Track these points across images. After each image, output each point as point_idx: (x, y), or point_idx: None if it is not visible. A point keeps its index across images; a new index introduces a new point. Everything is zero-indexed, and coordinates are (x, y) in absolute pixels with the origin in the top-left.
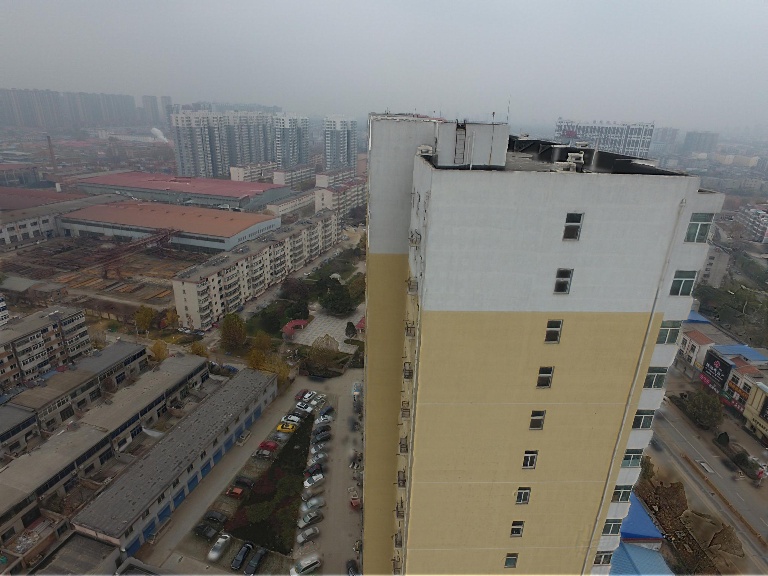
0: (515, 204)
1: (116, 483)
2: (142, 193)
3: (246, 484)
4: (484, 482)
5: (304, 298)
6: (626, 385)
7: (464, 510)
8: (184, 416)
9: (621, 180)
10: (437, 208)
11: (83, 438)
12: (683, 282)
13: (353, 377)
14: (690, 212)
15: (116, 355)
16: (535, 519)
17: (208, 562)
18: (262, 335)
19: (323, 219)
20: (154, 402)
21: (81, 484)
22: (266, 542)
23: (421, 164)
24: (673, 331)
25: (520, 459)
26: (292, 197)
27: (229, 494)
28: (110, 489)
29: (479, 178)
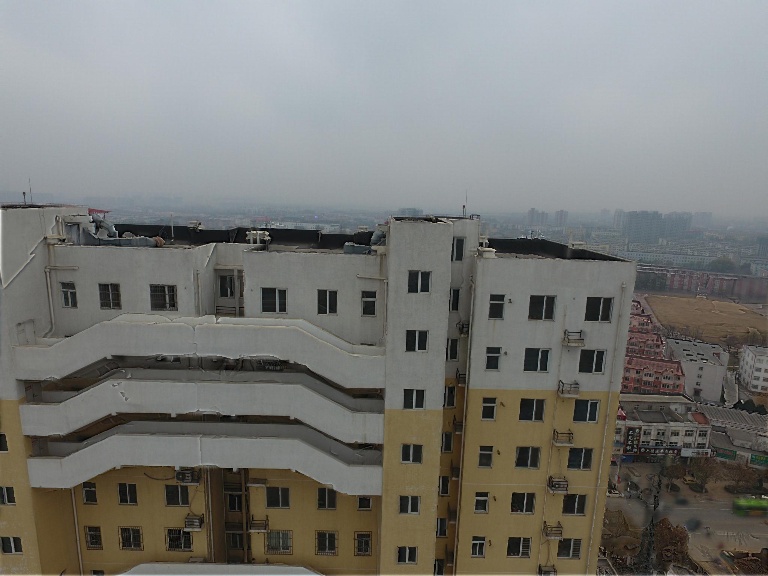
0: None
1: None
2: None
3: None
4: None
5: None
6: None
7: None
8: None
9: None
10: None
11: None
12: None
13: None
14: None
15: None
16: None
17: None
18: None
19: None
20: None
21: None
22: None
23: (556, 264)
24: None
25: None
26: None
27: None
28: None
29: None
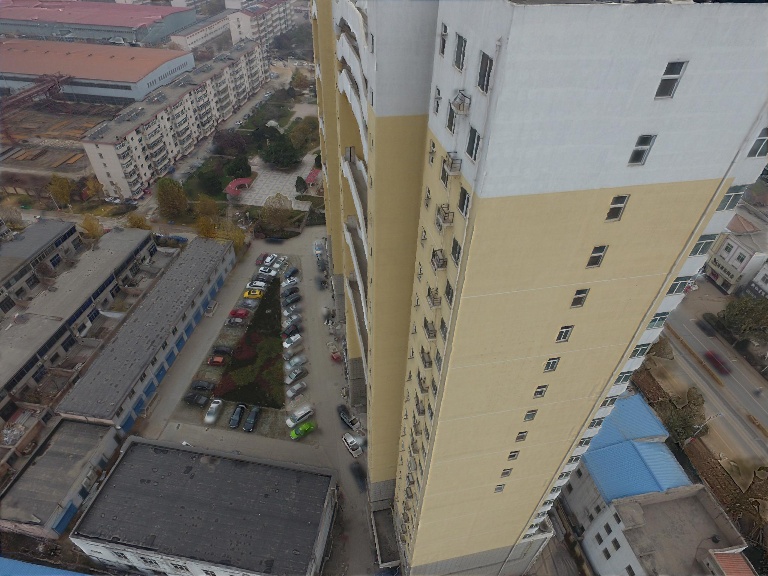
0: (611, 53)
1: (90, 369)
2: (2, 26)
3: (225, 352)
4: (518, 359)
5: (241, 152)
6: (673, 255)
7: (495, 384)
8: (142, 294)
9: (744, 12)
10: (513, 64)
11: (37, 329)
12: (765, 141)
13: (312, 235)
14: None
15: (42, 236)
16: (558, 382)
17: (206, 425)
18: (206, 199)
19: (245, 53)
20: (104, 283)
21: (51, 373)
22: (258, 401)
23: None
24: (736, 196)
25: (555, 335)
26: (200, 24)
27: (210, 363)
28: (86, 376)
29: (574, 16)
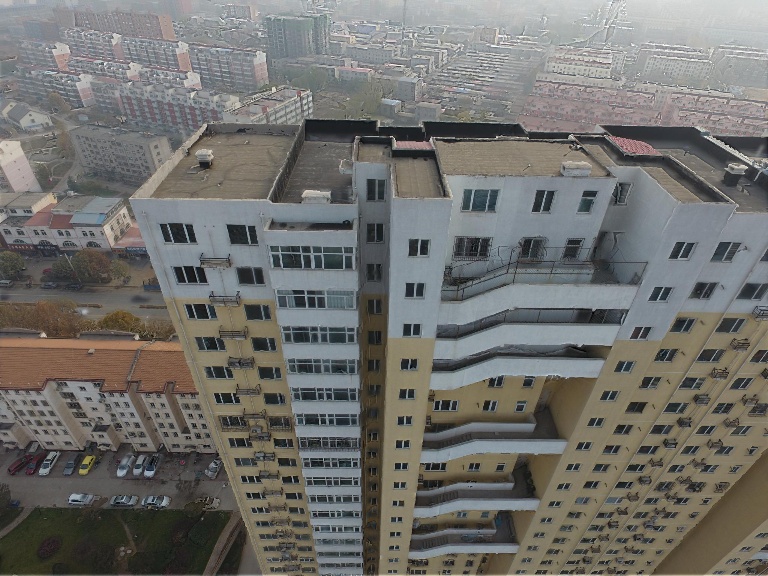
0: None
1: None
2: None
3: None
4: None
5: None
6: None
7: None
8: None
9: None
10: None
11: None
12: None
13: None
14: None
15: None
16: None
17: None
18: None
19: None
20: None
21: None
22: None
23: None
24: None
25: None
26: None
27: None
28: None
29: None
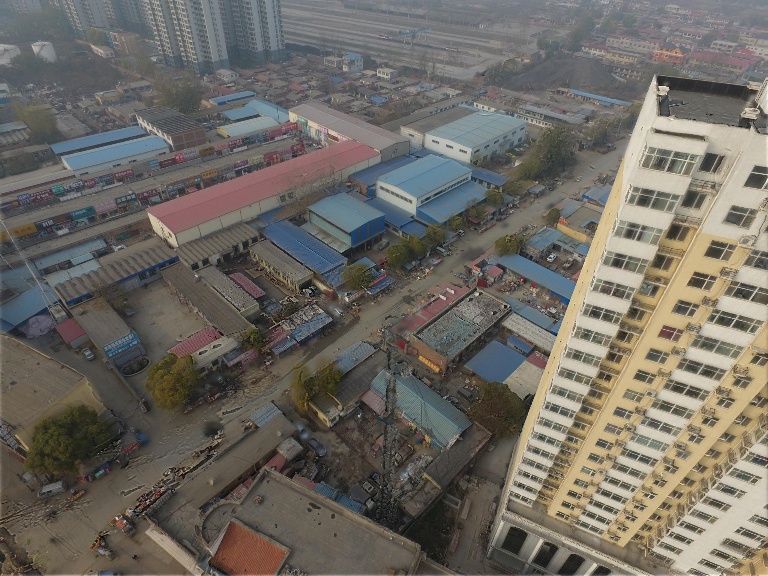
0: None
1: None
2: None
3: None
4: None
5: None
6: None
7: None
8: None
9: None
10: None
11: None
12: None
13: None
14: (646, 139)
15: None
16: None
17: None
18: None
19: None
20: None
21: None
22: None
23: None
24: None
25: None
26: None
27: None
28: None
29: None
